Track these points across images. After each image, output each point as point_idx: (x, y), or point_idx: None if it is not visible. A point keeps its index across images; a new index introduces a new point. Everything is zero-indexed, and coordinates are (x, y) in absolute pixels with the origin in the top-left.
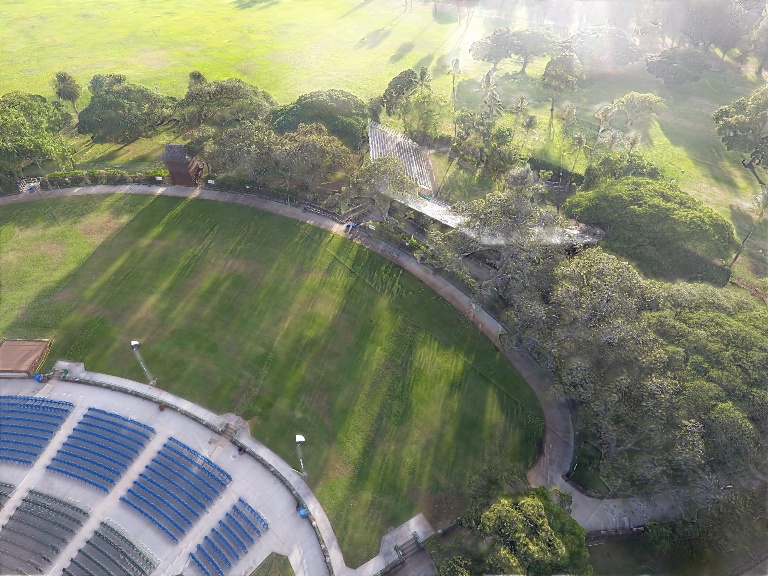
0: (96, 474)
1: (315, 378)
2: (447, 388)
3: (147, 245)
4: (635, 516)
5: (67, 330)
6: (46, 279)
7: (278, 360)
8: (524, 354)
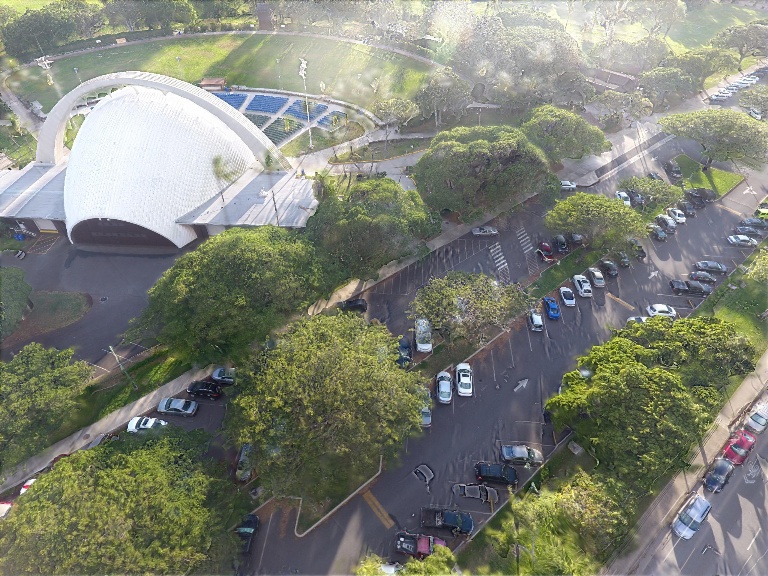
0: (269, 109)
1: (358, 84)
2: (420, 82)
3: (257, 51)
4: (497, 107)
5: (232, 76)
6: (210, 62)
7: (339, 80)
8: (455, 72)
